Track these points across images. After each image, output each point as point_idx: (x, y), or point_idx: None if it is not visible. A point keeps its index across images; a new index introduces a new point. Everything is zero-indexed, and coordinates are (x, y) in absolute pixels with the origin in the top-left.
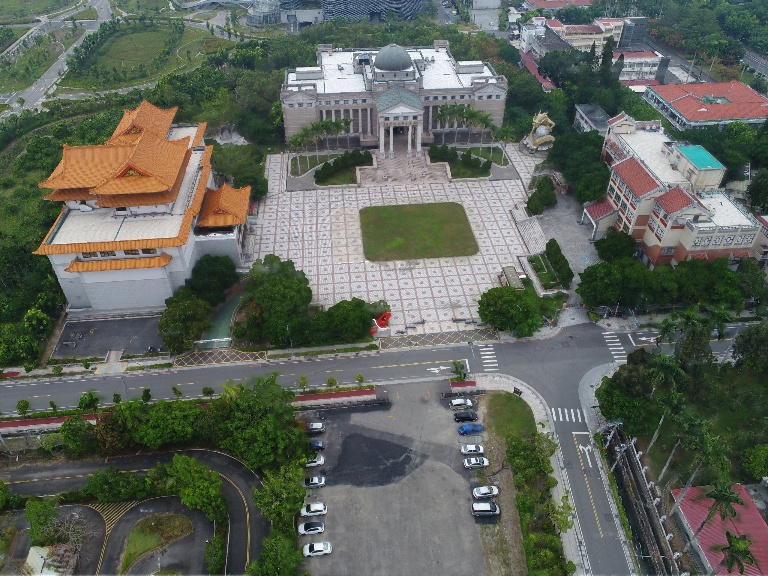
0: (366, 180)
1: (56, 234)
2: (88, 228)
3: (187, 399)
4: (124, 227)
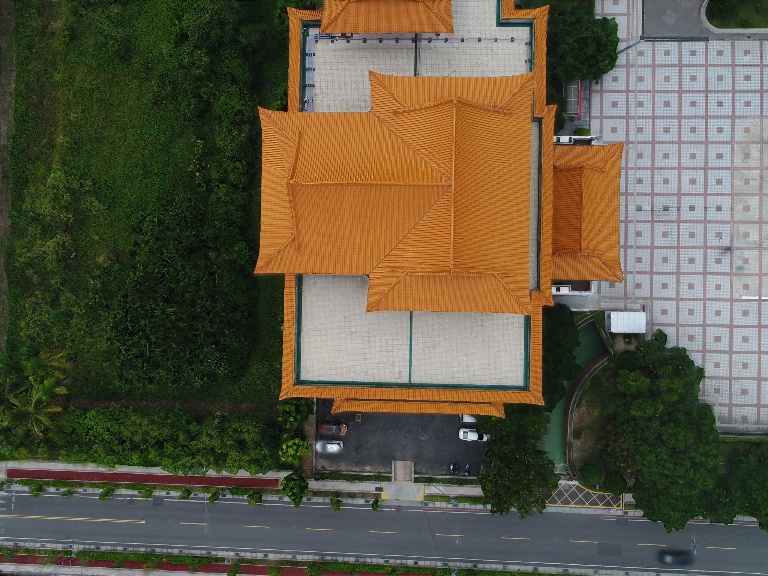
0: None
1: (300, 338)
2: (353, 325)
3: (518, 567)
4: (418, 329)
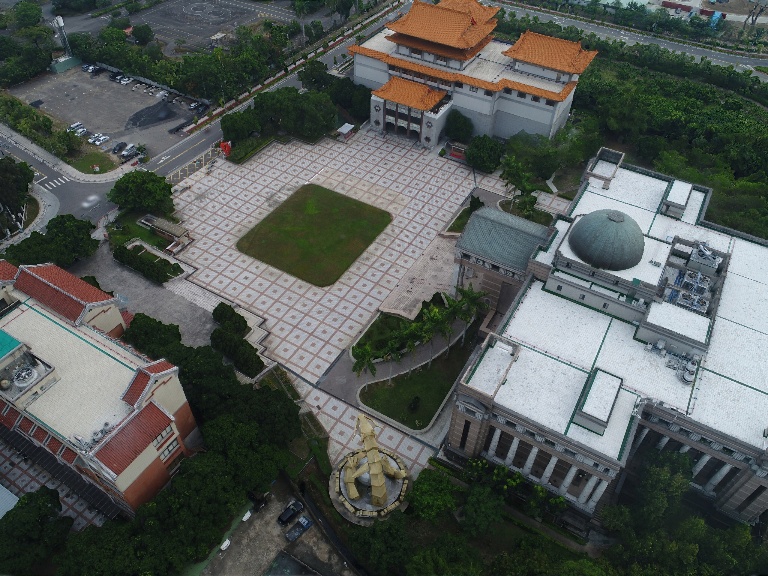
0: (446, 242)
1: None
2: None
3: (275, 86)
4: None
